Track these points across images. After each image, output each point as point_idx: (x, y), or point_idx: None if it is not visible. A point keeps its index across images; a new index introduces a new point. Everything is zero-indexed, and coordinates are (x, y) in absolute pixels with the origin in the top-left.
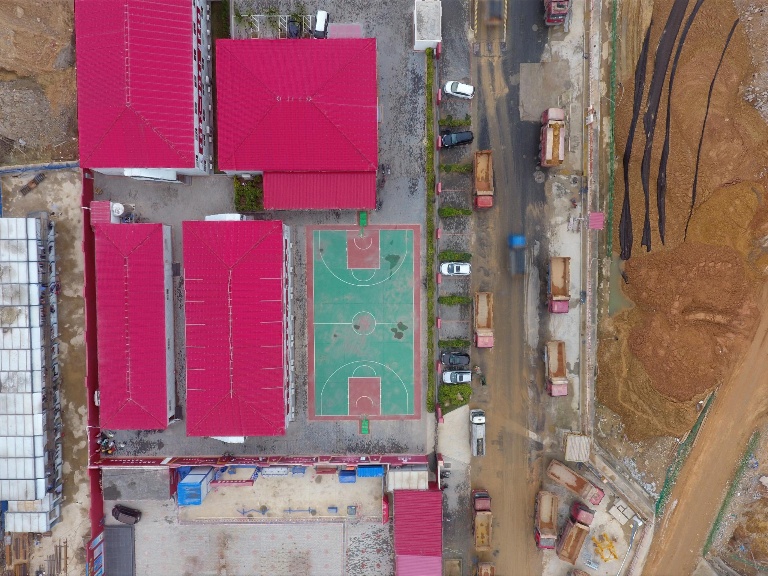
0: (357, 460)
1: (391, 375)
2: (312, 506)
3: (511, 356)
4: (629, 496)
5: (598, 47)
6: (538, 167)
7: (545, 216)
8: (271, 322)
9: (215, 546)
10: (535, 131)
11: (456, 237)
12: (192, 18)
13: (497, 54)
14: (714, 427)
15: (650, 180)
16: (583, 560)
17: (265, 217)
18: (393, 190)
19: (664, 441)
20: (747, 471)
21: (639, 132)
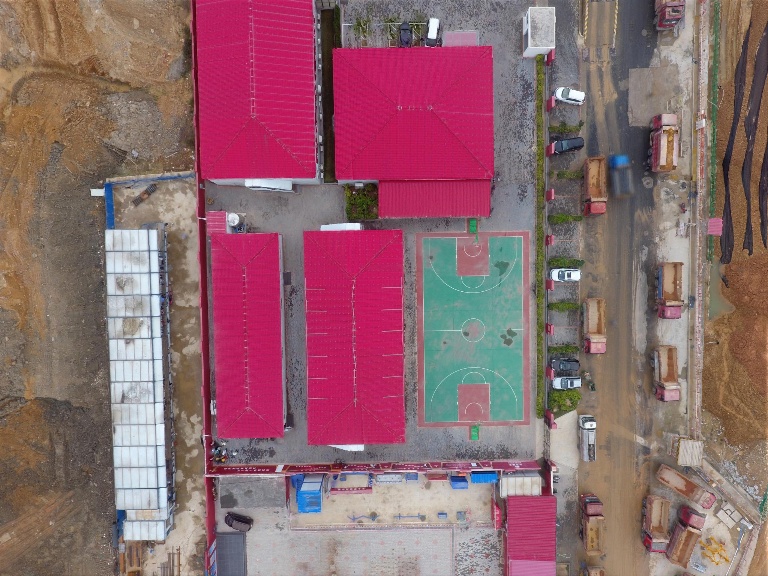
0: (469, 466)
1: (500, 381)
2: (422, 512)
3: (619, 361)
4: (736, 499)
5: (707, 51)
6: (647, 172)
7: (653, 221)
8: (392, 331)
9: (325, 552)
10: (644, 136)
11: (565, 243)
12: None
13: (606, 60)
14: None
15: (751, 183)
16: (691, 563)
17: (375, 225)
18: (502, 197)
19: (765, 444)
20: None
21: (740, 135)
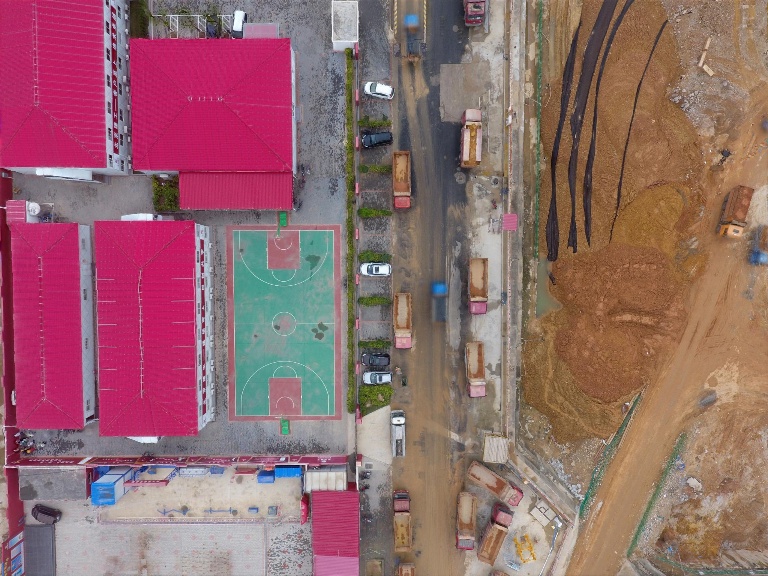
0: (276, 460)
1: (312, 376)
2: (233, 506)
3: (433, 357)
4: (551, 497)
5: (519, 48)
6: (459, 168)
7: (466, 217)
8: (183, 322)
9: (136, 546)
10: (456, 132)
11: (377, 238)
12: (103, 18)
13: (417, 55)
14: (640, 429)
15: (577, 181)
16: (505, 561)
17: (185, 217)
18: (313, 190)
19: (590, 442)
20: (673, 473)
21: (566, 133)
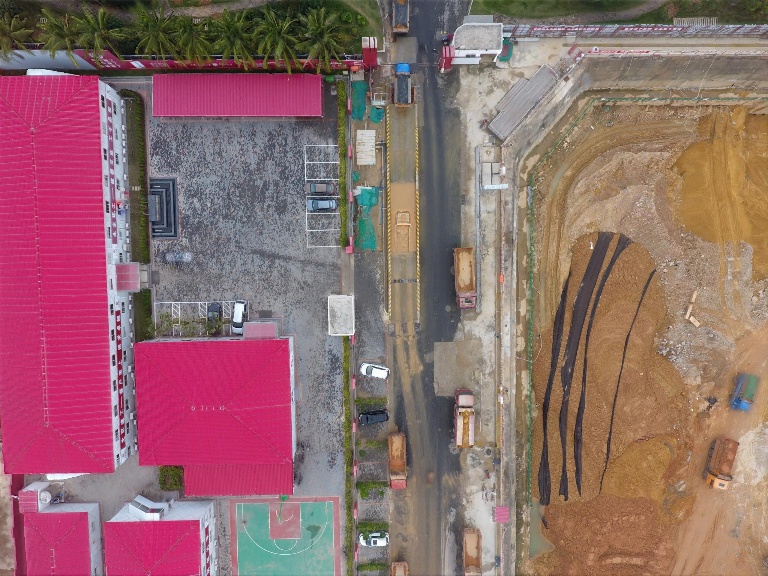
0: None
1: None
2: None
3: None
4: None
5: (509, 326)
6: (453, 439)
7: (460, 485)
8: None
9: None
10: (450, 405)
11: (375, 506)
12: (109, 332)
13: (412, 334)
14: None
15: (568, 431)
16: None
17: None
18: (313, 464)
19: None
20: None
21: (557, 385)
